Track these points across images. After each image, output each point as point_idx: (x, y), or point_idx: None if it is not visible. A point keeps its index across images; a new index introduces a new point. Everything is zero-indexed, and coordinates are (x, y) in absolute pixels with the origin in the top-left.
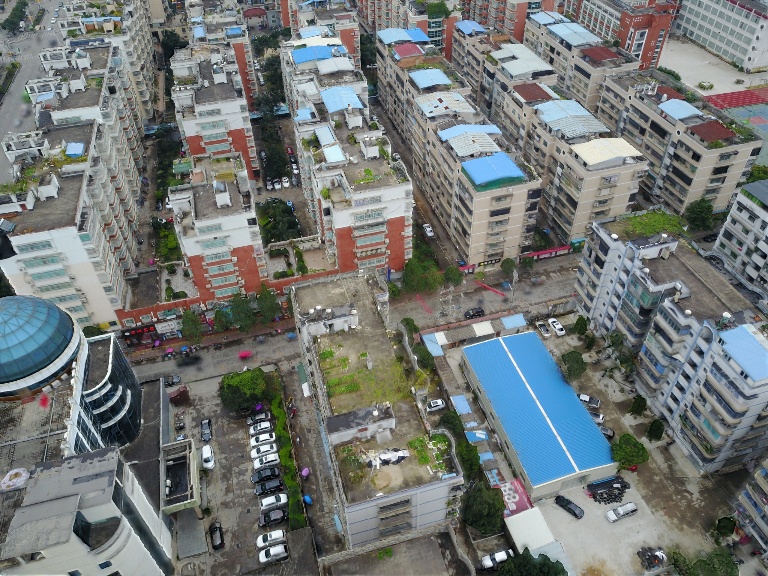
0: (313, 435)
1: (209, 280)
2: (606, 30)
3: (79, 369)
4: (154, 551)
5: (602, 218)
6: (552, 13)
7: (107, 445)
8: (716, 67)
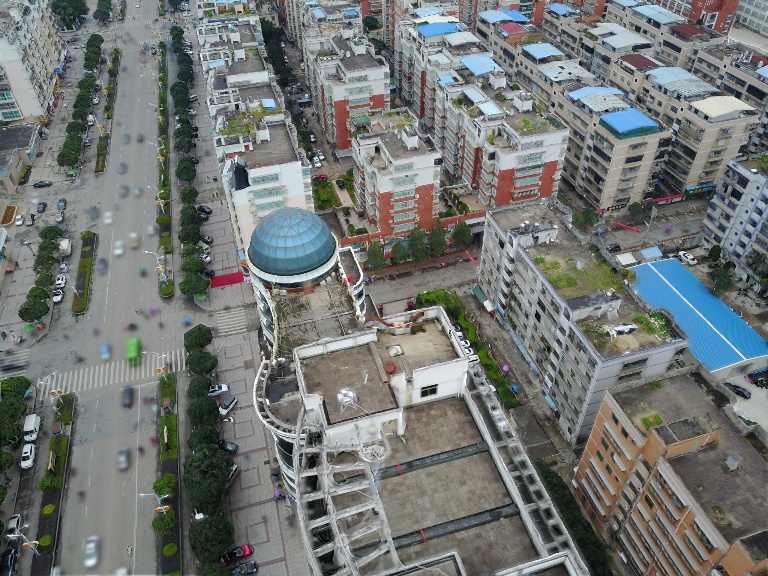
0: (500, 342)
1: (393, 216)
2: None
3: None
4: None
5: (714, 168)
6: None
7: None
8: None
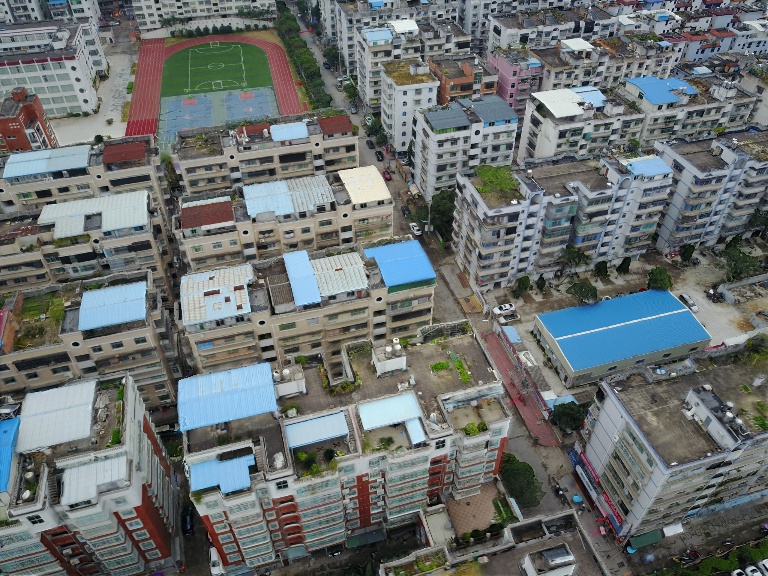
0: (712, 529)
1: None
2: None
3: None
4: None
5: None
6: None
7: None
8: (65, 126)
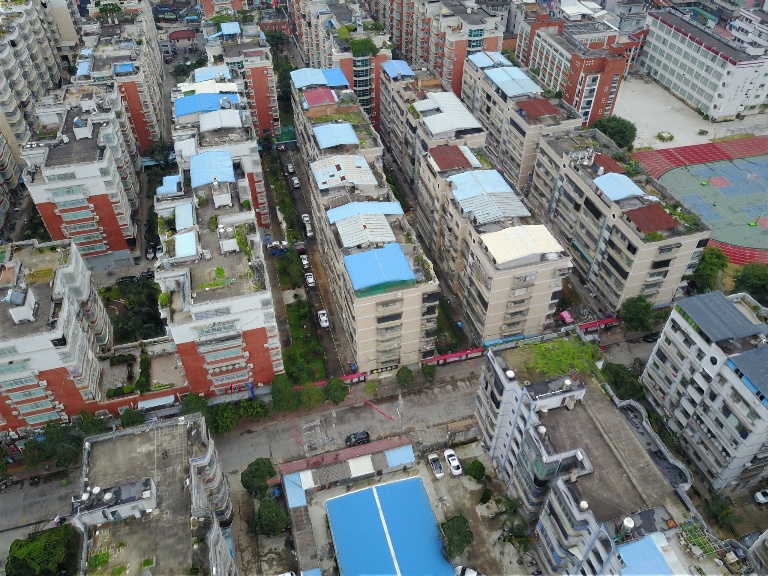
0: None
1: (14, 407)
2: (557, 71)
3: None
4: None
5: (520, 318)
6: (493, 54)
7: None
8: (679, 113)
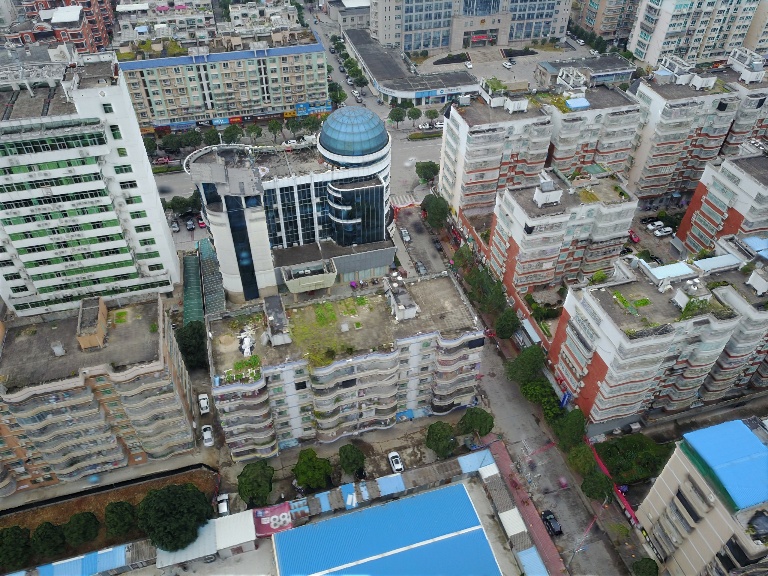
0: None
1: (493, 243)
2: None
3: (341, 172)
4: (248, 266)
5: None
6: None
7: (324, 226)
8: None
